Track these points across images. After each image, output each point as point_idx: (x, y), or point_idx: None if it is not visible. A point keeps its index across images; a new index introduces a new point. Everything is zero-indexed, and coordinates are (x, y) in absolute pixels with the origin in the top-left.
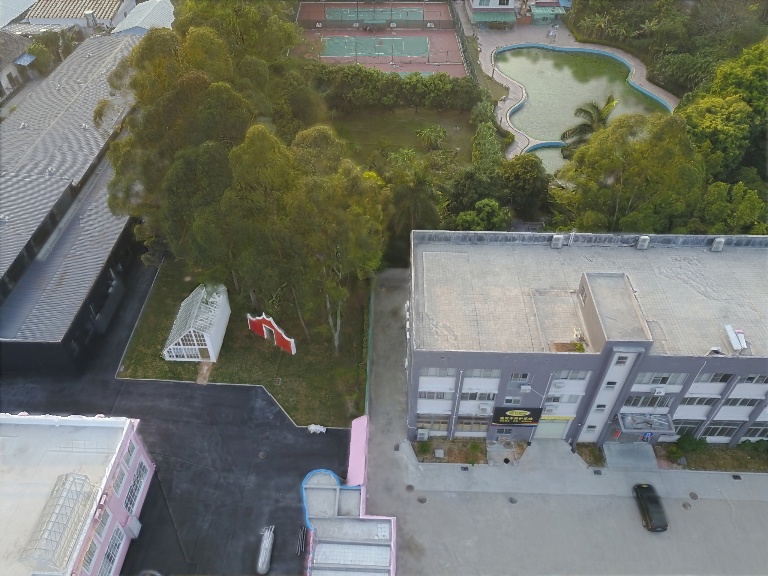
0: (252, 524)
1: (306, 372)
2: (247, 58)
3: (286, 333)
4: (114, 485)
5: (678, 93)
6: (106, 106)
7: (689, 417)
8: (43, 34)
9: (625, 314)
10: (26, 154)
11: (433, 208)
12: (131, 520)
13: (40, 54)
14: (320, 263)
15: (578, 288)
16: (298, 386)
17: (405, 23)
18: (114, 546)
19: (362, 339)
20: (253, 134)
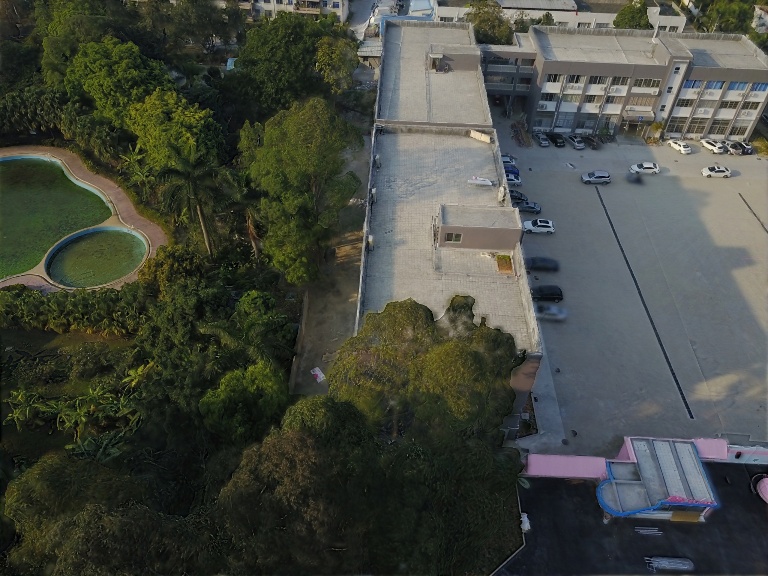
0: None
1: None
2: None
3: None
4: None
5: (11, 142)
6: None
7: None
8: None
9: (488, 216)
10: None
11: (273, 339)
12: None
13: None
14: None
15: (430, 244)
16: None
17: None
18: None
19: None
20: (471, 355)
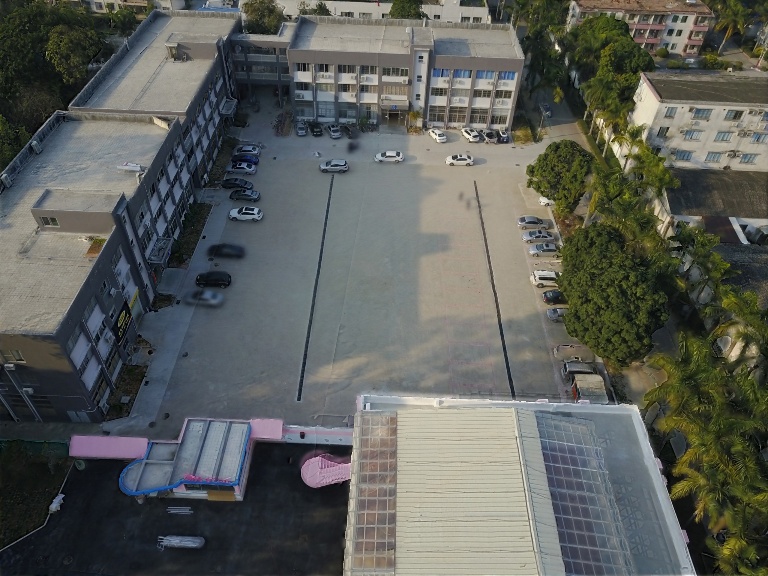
0: (150, 560)
1: None
2: None
3: None
4: None
5: None
6: None
7: (163, 231)
8: None
9: (89, 200)
10: None
11: None
12: None
13: None
14: None
15: (33, 229)
16: None
17: None
18: None
19: None
20: None
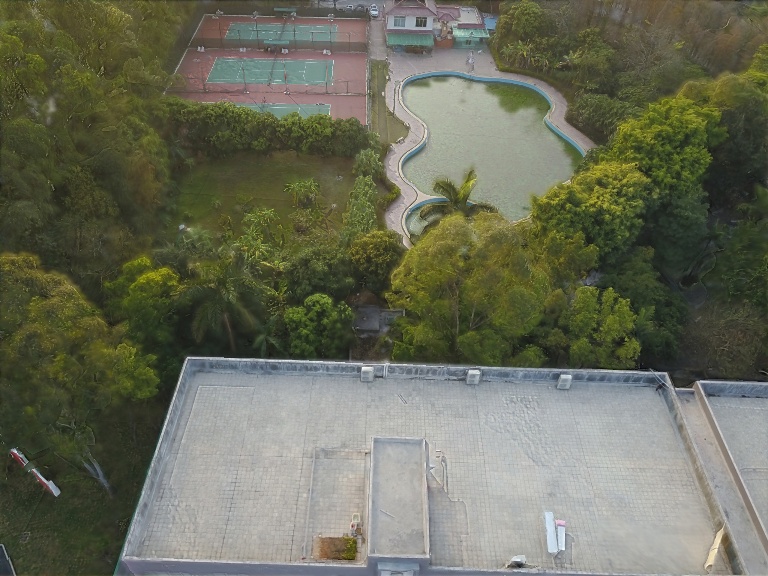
0: None
1: (65, 523)
2: (13, 123)
3: (43, 473)
4: None
5: (595, 138)
6: None
7: None
8: None
9: (407, 507)
10: None
11: (241, 312)
12: None
13: None
14: None
15: None
16: (49, 545)
17: (311, 44)
18: None
19: None
20: None
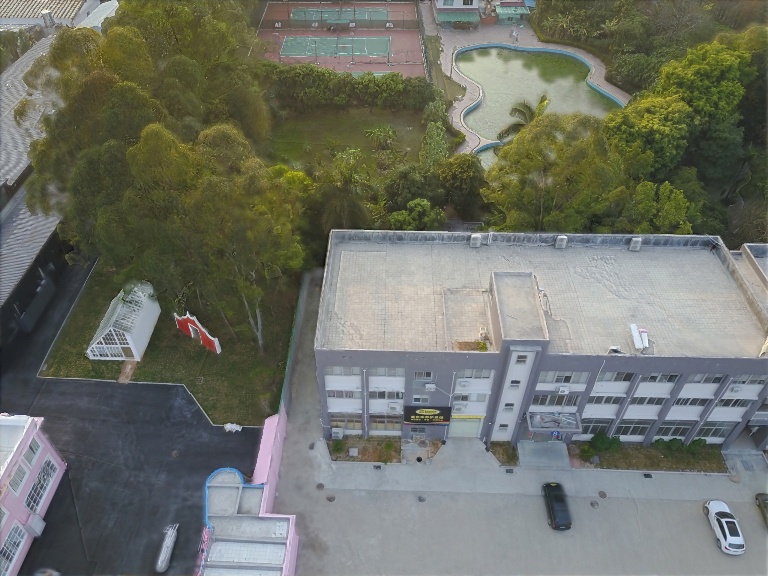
0: (157, 522)
1: (229, 371)
2: (176, 58)
3: (210, 332)
4: (12, 483)
5: None
6: (27, 106)
7: (598, 416)
8: (1, 34)
9: (527, 313)
10: None
11: (361, 207)
12: (33, 518)
13: None
14: (231, 262)
15: None
16: (219, 385)
17: (369, 23)
18: (12, 544)
19: (289, 338)
20: (147, 133)
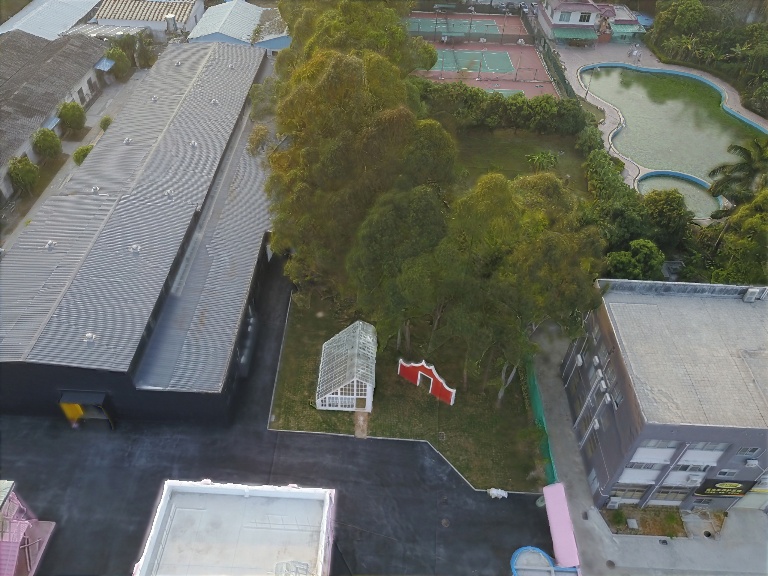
0: None
1: (470, 426)
2: None
3: (447, 383)
4: None
5: None
6: (268, 134)
7: None
8: (120, 37)
9: None
10: (139, 173)
11: None
12: None
13: (119, 59)
14: None
15: None
16: (465, 442)
17: (483, 37)
18: None
19: (521, 389)
20: (495, 185)
